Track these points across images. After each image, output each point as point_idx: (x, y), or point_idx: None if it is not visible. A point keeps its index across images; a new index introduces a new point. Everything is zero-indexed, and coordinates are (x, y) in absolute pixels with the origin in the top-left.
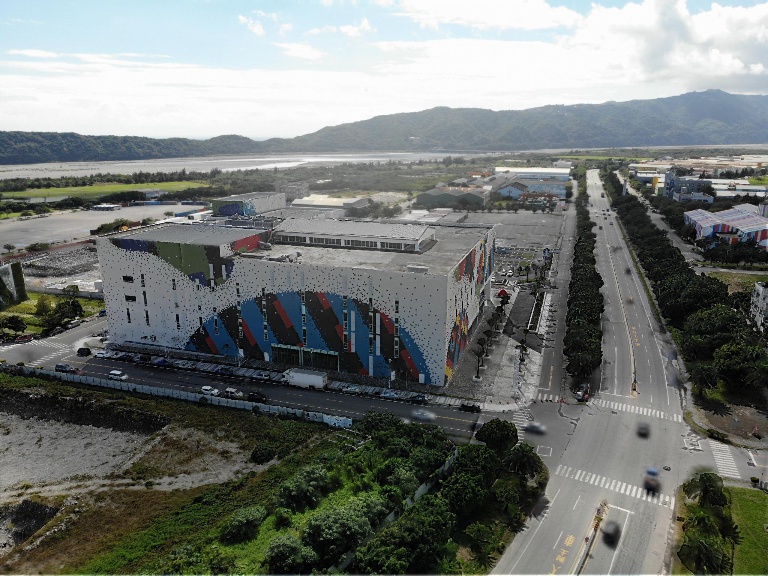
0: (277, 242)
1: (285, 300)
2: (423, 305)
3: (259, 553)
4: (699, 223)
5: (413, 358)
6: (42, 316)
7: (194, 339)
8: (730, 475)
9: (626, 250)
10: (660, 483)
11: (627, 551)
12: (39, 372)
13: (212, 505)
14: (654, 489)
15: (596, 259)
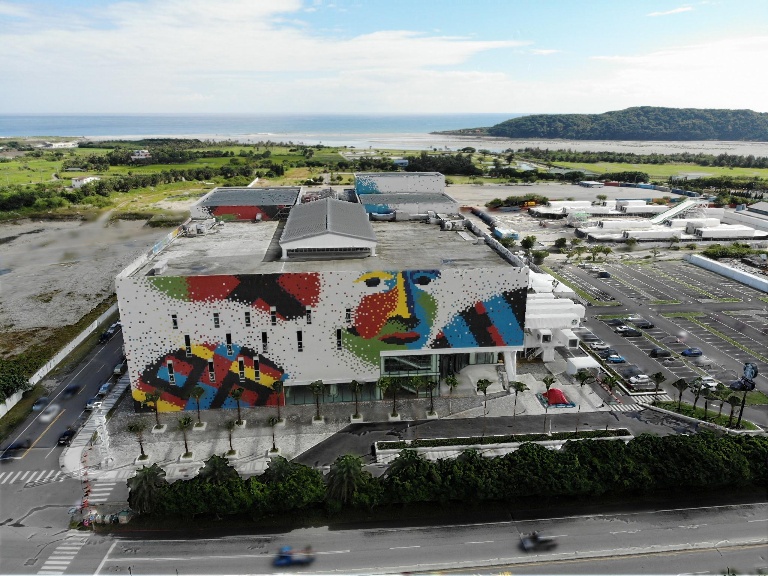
0: None
1: None
2: None
3: None
4: None
5: None
6: None
7: None
8: None
9: None
10: None
11: None
12: None
13: None
14: None
15: None
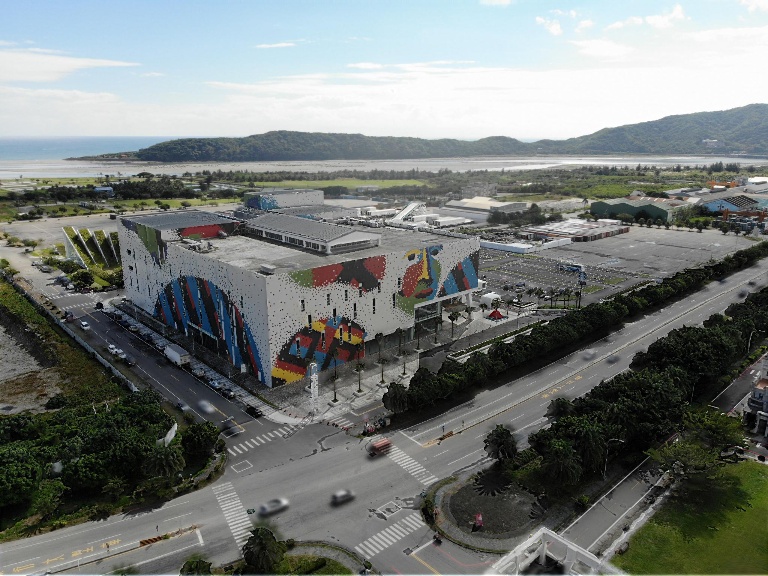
0: (246, 233)
1: (191, 283)
2: (255, 303)
3: None
4: None
5: (254, 354)
6: (104, 275)
7: (157, 308)
8: (363, 552)
9: None
10: (279, 531)
11: (132, 571)
12: None
13: None
14: None
15: (694, 295)
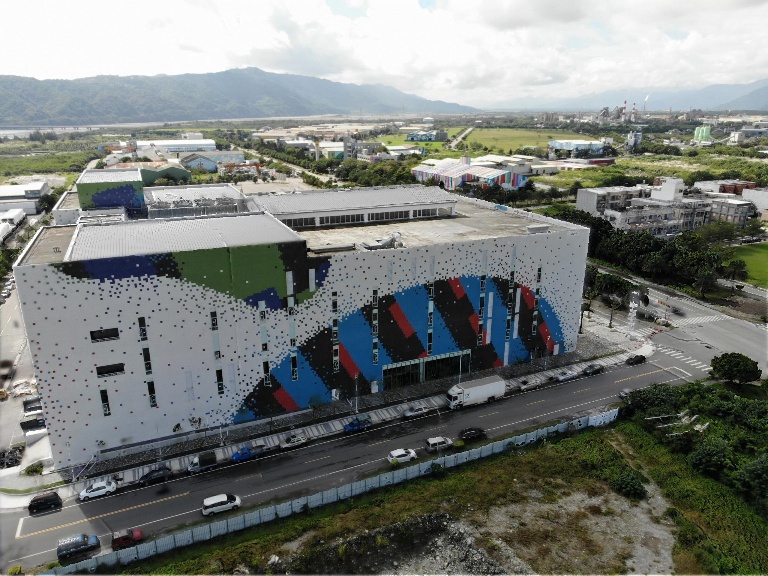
0: None
1: (406, 300)
2: (565, 267)
3: None
4: (444, 175)
5: (550, 330)
6: None
7: (252, 401)
8: None
9: None
10: None
11: None
12: None
13: (739, 567)
14: None
15: None
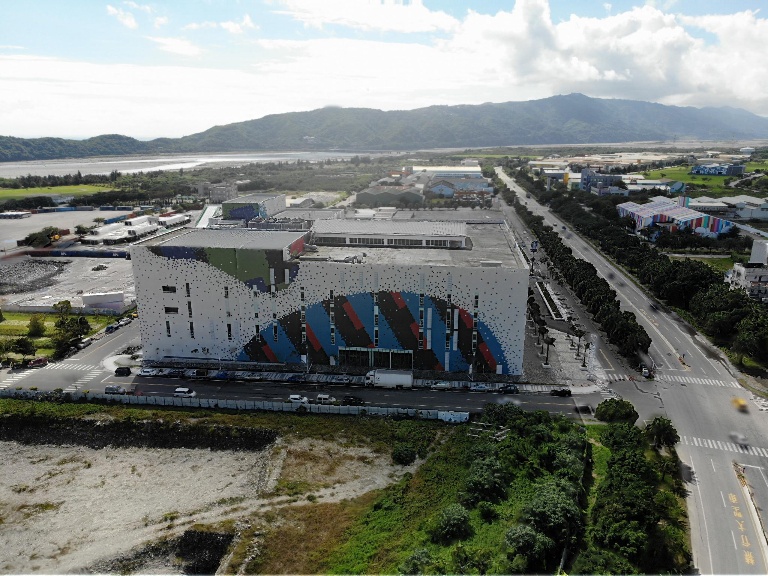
0: (315, 244)
1: (356, 302)
2: (503, 298)
3: (491, 547)
4: (638, 214)
5: (491, 350)
6: (53, 336)
7: (248, 349)
8: None
9: (582, 241)
10: (764, 441)
11: None
12: (91, 397)
13: (395, 510)
14: (764, 446)
15: None
